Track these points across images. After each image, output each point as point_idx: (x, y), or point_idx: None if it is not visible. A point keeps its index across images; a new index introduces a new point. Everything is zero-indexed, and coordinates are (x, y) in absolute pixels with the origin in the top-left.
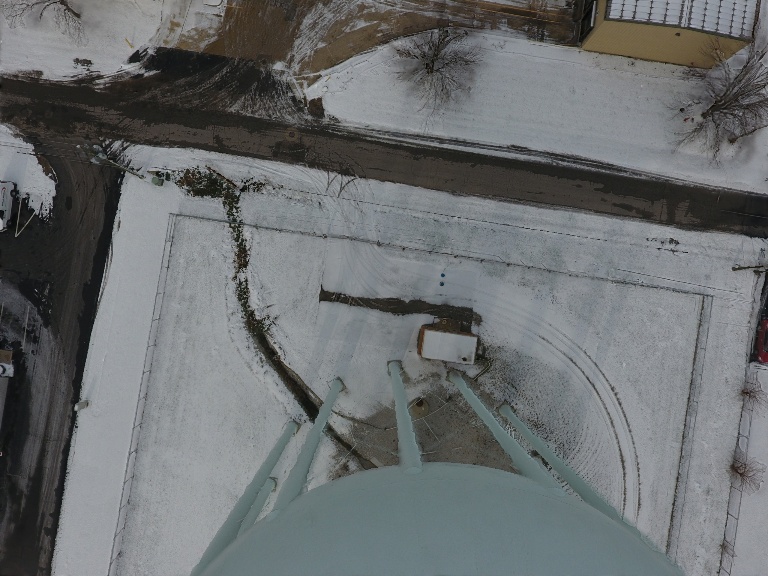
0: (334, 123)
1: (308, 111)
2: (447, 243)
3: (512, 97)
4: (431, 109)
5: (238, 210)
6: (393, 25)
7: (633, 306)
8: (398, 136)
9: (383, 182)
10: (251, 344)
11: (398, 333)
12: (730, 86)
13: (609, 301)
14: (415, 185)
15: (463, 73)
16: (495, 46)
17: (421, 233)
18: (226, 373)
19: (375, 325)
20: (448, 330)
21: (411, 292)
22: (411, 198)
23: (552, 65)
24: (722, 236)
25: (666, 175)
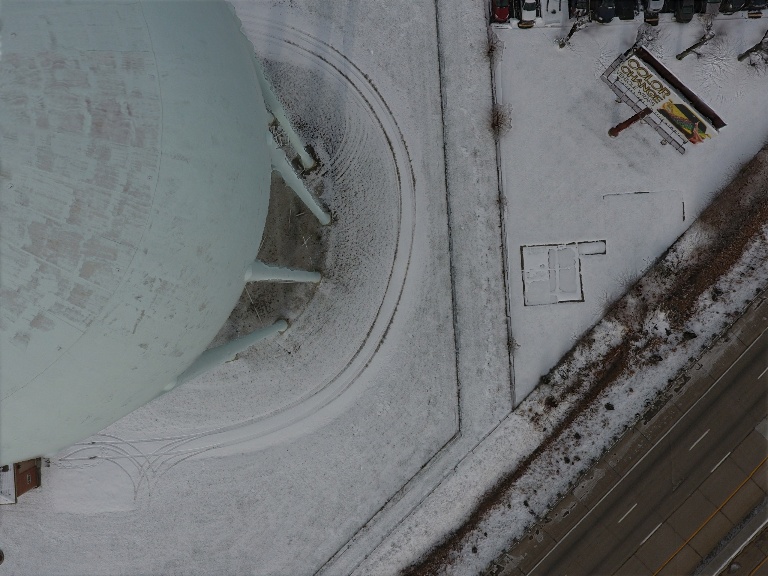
0: None
1: None
2: None
3: None
4: None
5: None
6: None
7: None
8: None
9: None
10: None
11: None
12: None
13: None
14: None
15: None
16: None
17: None
18: None
19: None
20: None
21: None
22: None
23: None
24: None
25: None
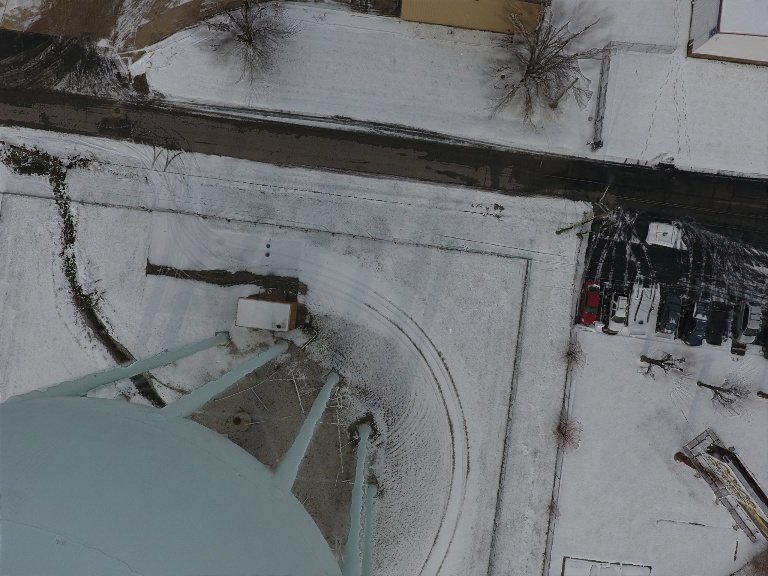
0: (159, 98)
1: (133, 87)
2: (272, 214)
3: (334, 68)
4: (255, 82)
5: (64, 187)
6: (216, 0)
7: (458, 272)
8: (223, 110)
9: (209, 155)
10: (79, 319)
11: (225, 304)
12: (532, 49)
13: (434, 267)
14: (241, 158)
15: (285, 46)
16: (315, 18)
17: (246, 205)
18: (55, 349)
19: (202, 297)
20: (273, 300)
21: (237, 263)
22: (237, 171)
23: (372, 36)
24: (545, 200)
25: (489, 142)
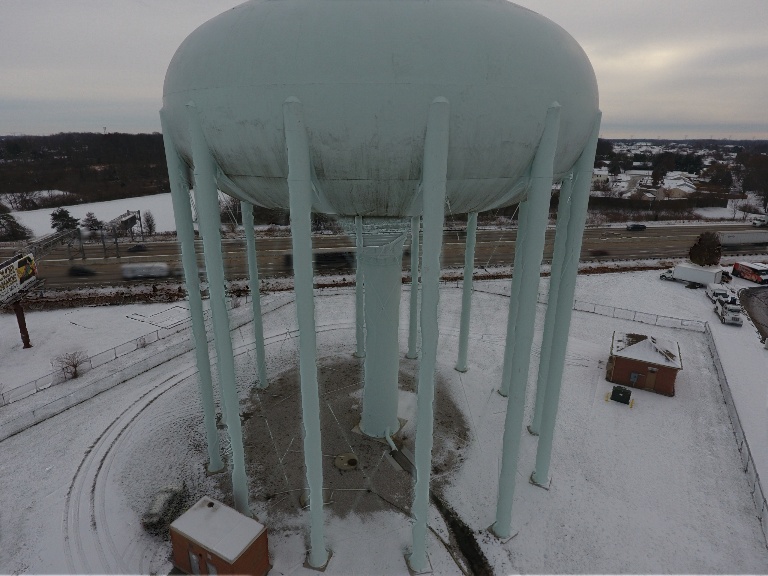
0: None
1: None
2: None
3: None
4: None
5: None
6: None
7: None
8: None
9: None
10: None
11: None
12: None
13: None
14: None
15: None
16: None
17: None
18: None
19: None
20: None
21: None
22: None
23: None
24: None
25: None
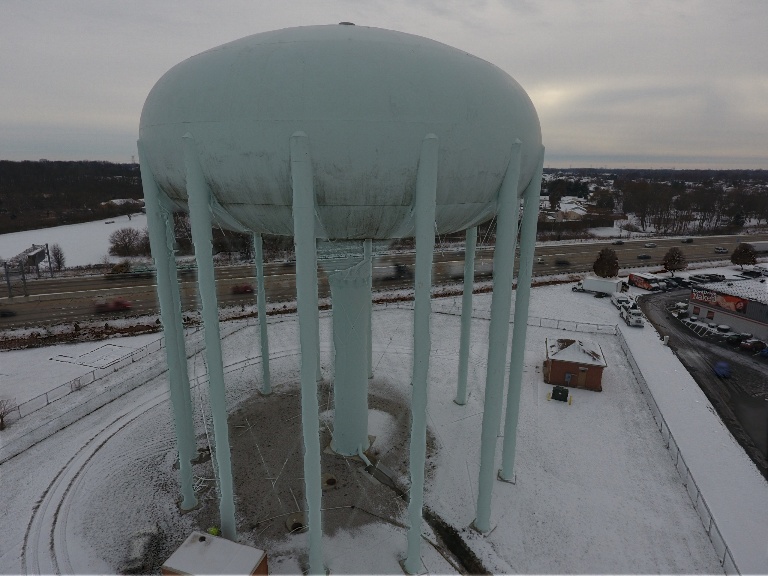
0: None
1: None
2: None
3: None
4: None
5: None
6: None
7: None
8: None
9: None
10: None
11: None
12: None
13: None
14: None
15: None
16: None
17: None
18: None
19: None
20: None
21: None
22: None
23: None
24: None
25: None
